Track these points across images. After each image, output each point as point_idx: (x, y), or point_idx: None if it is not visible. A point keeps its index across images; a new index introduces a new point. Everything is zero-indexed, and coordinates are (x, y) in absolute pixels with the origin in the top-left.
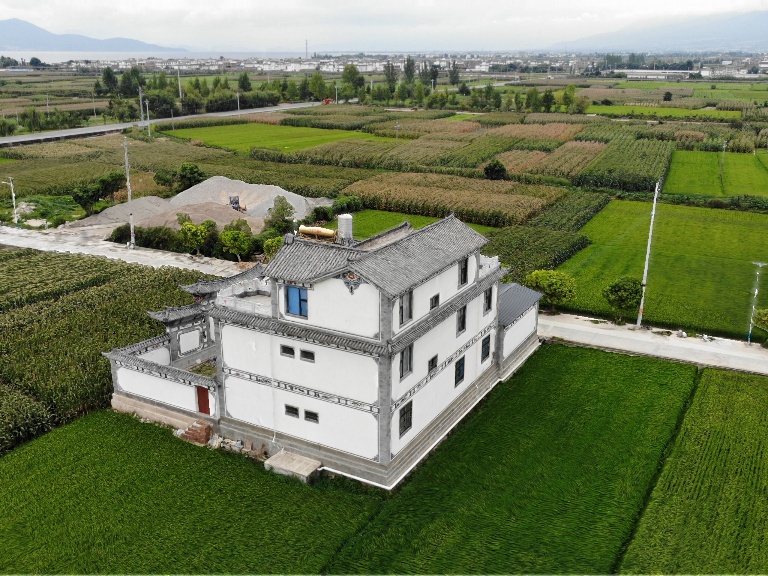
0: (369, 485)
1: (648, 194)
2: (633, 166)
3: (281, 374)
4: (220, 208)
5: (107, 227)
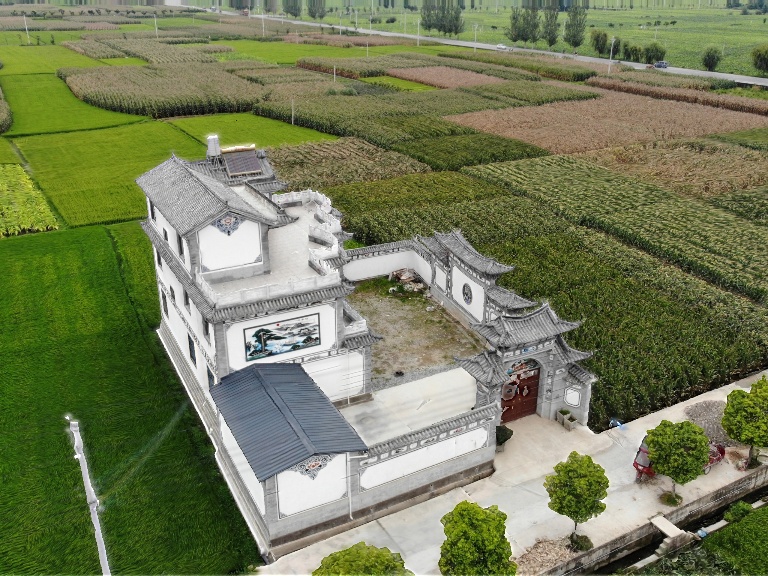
0: None
1: None
2: None
3: None
4: None
5: None
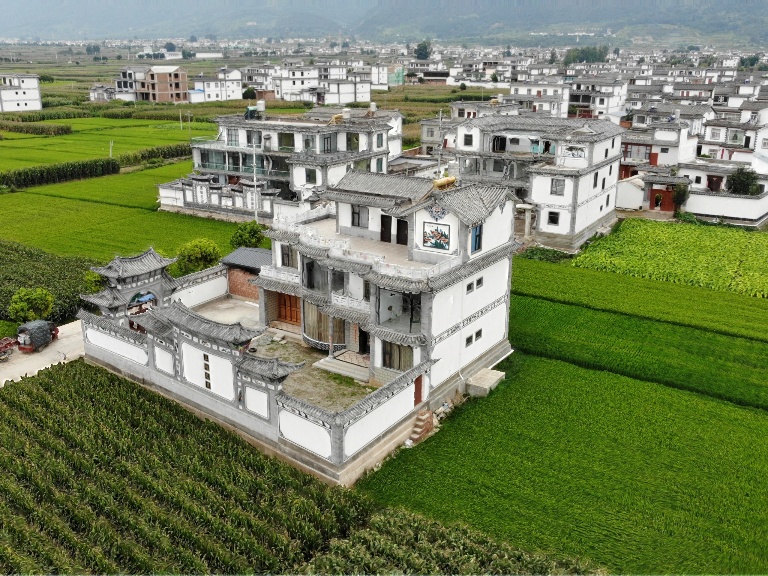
0: (505, 359)
1: None
2: None
3: (465, 312)
4: None
5: None
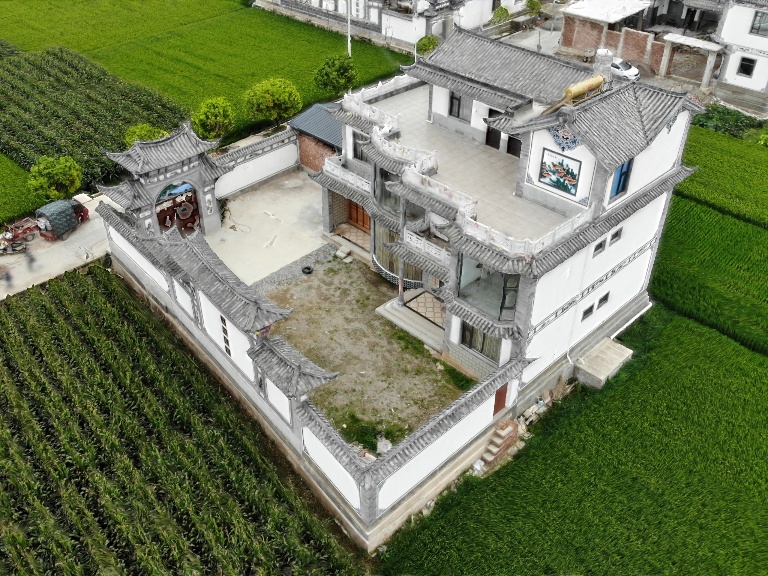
0: (638, 317)
1: None
2: None
3: (587, 281)
4: None
5: None
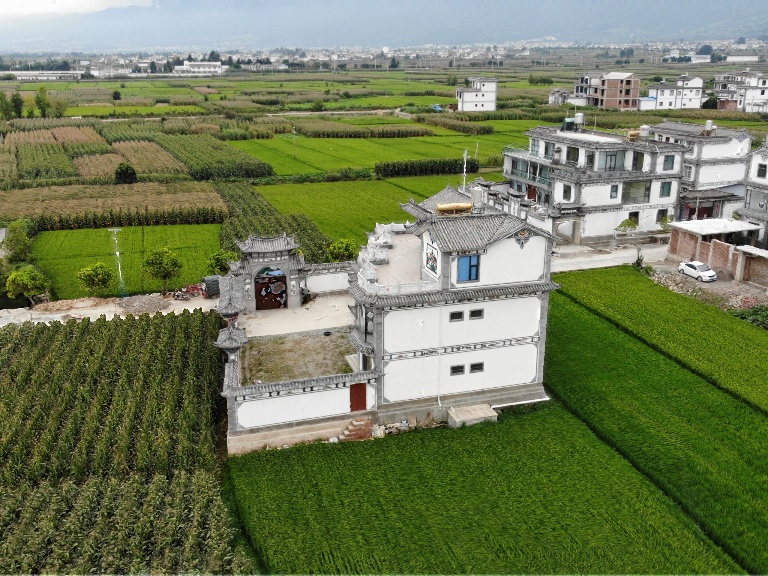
0: (531, 404)
1: (272, 178)
2: (229, 156)
3: (448, 340)
4: None
5: None
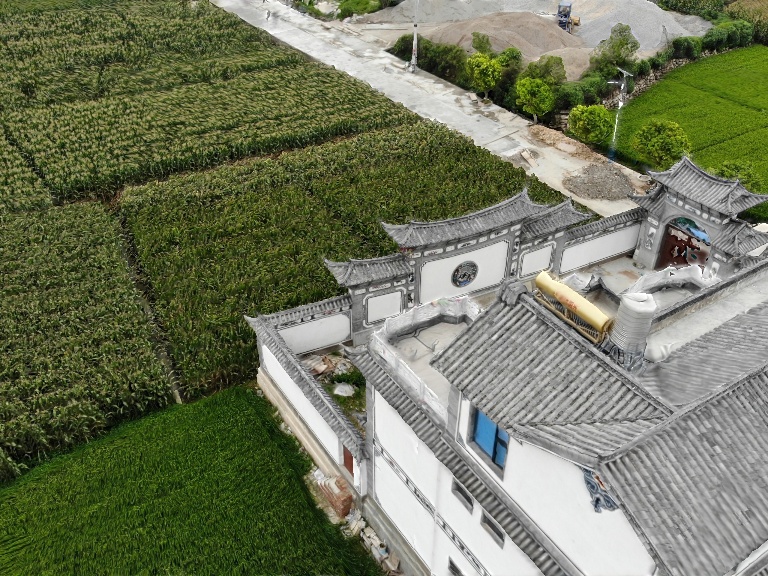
0: None
1: None
2: None
3: (449, 516)
4: (539, 24)
5: (397, 29)
